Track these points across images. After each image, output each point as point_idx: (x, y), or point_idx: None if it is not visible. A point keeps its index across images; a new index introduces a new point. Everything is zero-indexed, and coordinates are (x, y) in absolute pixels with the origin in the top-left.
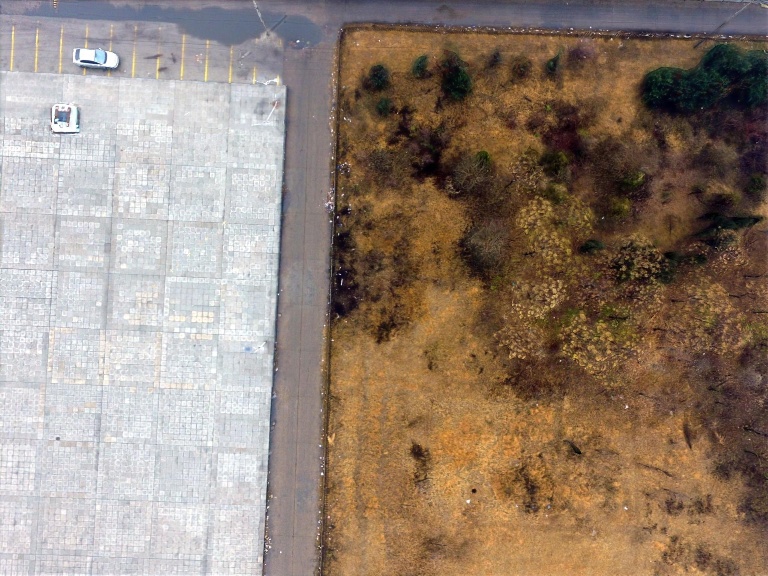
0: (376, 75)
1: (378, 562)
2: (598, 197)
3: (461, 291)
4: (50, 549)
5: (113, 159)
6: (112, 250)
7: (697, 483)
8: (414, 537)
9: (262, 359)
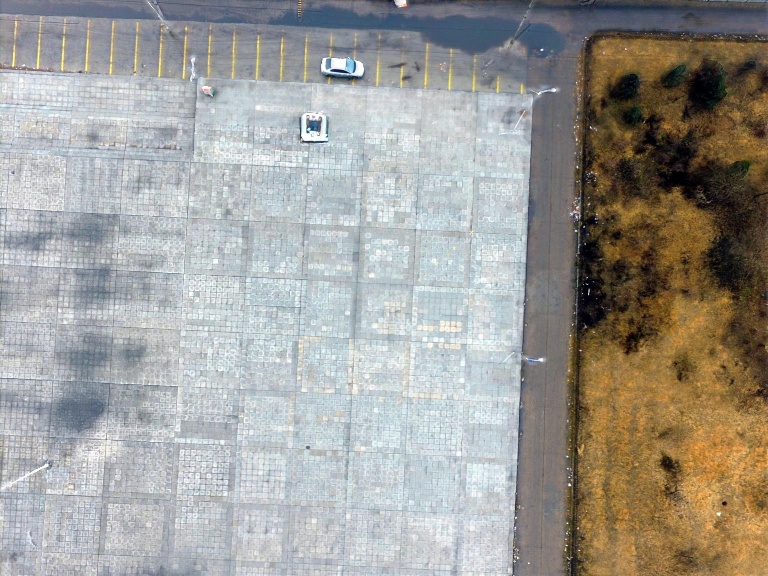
0: (631, 84)
1: (629, 574)
2: None
3: (710, 302)
4: (301, 558)
5: (361, 168)
6: (360, 259)
7: None
8: (665, 549)
9: (510, 369)
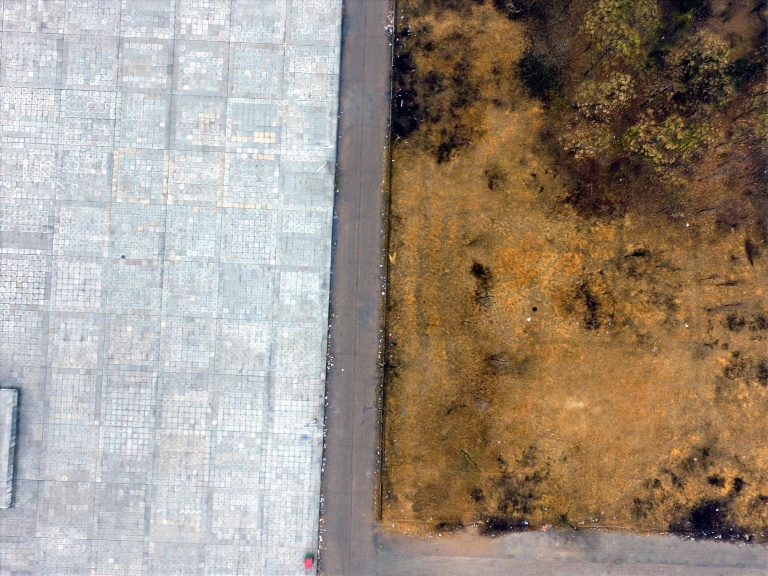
0: None
1: (440, 378)
2: (658, 17)
3: (521, 111)
4: (117, 364)
5: None
6: (175, 72)
7: (758, 300)
8: (475, 353)
9: (323, 179)
